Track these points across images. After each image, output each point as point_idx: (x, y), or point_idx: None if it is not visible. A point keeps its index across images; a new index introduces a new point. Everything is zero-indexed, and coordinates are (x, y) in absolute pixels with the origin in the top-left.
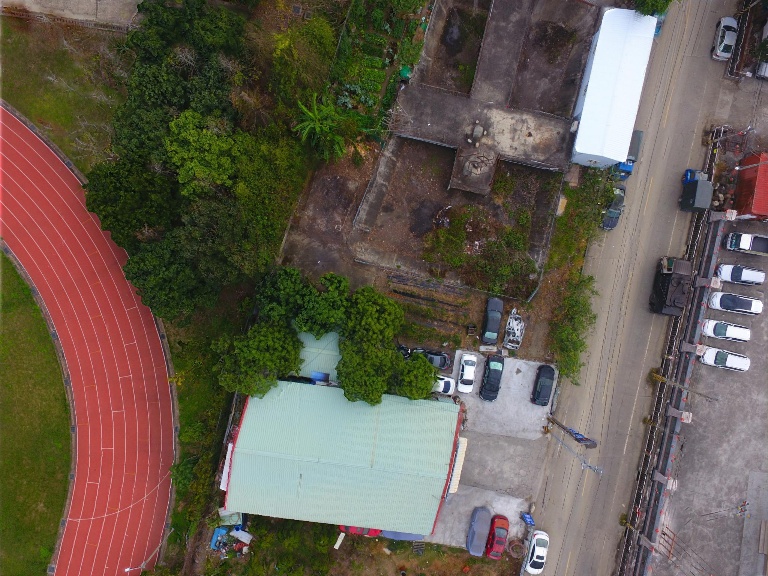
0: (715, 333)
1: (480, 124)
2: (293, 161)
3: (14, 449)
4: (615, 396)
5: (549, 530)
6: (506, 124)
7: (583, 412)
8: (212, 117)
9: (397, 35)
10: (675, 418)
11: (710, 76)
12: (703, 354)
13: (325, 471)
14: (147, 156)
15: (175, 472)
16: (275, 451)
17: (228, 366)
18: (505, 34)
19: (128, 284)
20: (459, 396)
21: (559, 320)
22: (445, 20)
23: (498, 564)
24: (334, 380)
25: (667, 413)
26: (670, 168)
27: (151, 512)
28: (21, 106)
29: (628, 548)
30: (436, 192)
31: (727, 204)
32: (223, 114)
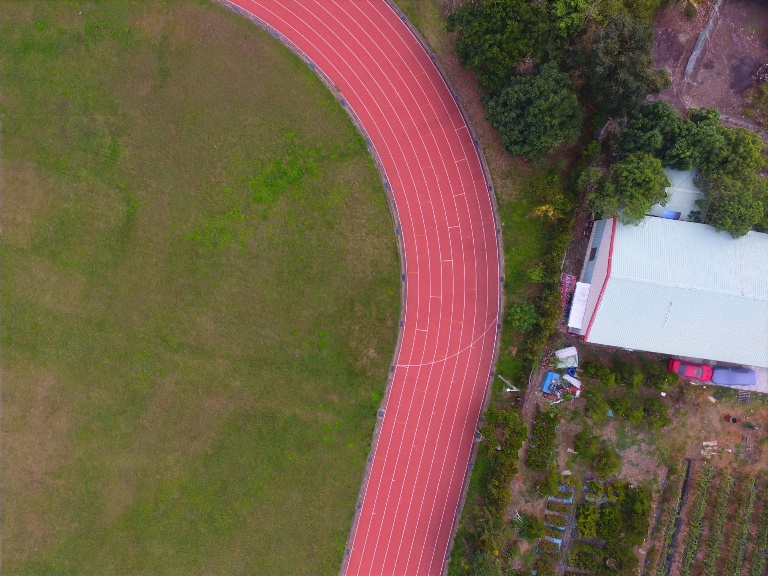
0: None
1: None
2: (654, 1)
3: (348, 296)
4: None
5: None
6: None
7: None
8: None
9: None
10: None
11: None
12: None
13: (696, 298)
14: None
15: (519, 312)
16: (650, 277)
17: (611, 191)
18: None
19: (458, 136)
20: None
21: None
22: None
23: None
24: (684, 219)
25: None
26: None
27: (477, 360)
28: None
29: None
30: (756, 49)
31: None
32: None
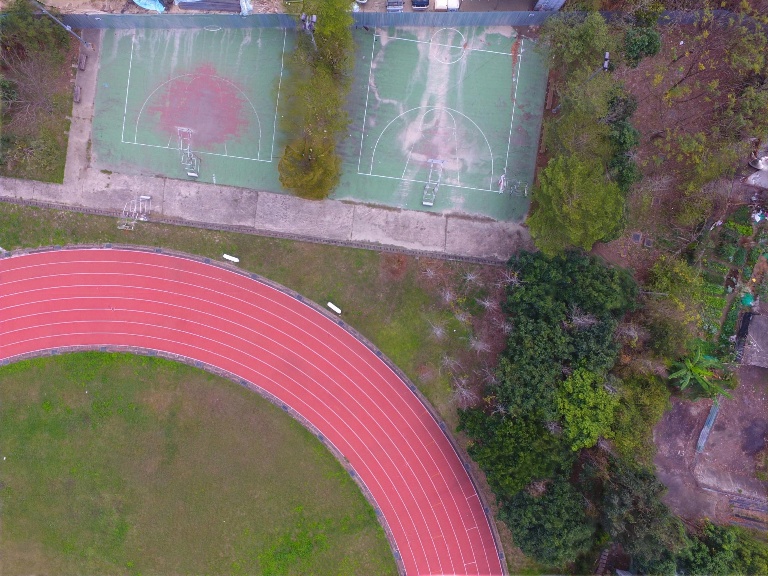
0: None
1: None
2: (666, 407)
3: None
4: None
5: None
6: None
7: None
8: None
9: (739, 263)
10: None
11: None
12: None
13: None
14: (541, 415)
15: None
16: None
17: None
18: None
19: (468, 505)
20: None
21: None
22: None
23: None
24: None
25: None
26: None
27: None
28: (368, 333)
29: None
30: (767, 411)
31: None
32: None
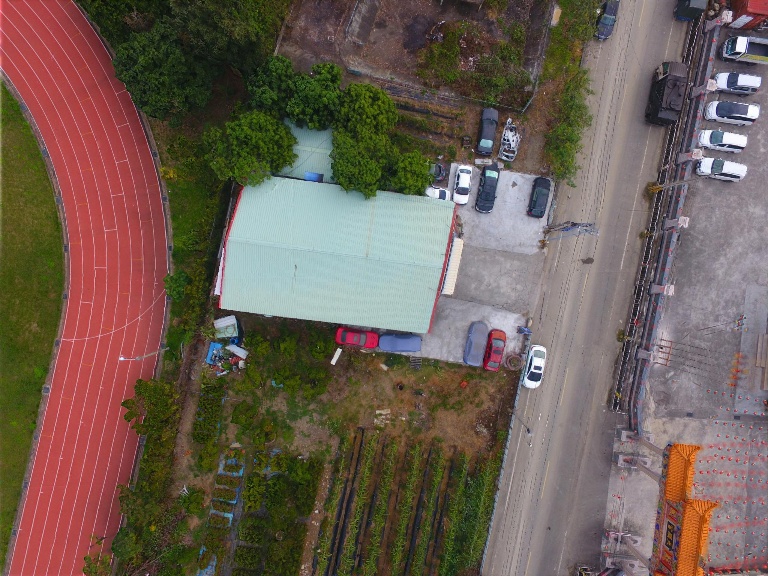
0: (711, 141)
1: None
2: None
3: (6, 268)
4: (611, 211)
5: (546, 345)
6: None
7: None
8: None
9: None
10: (672, 228)
11: None
12: (699, 164)
13: (320, 261)
14: None
15: (169, 280)
16: (269, 240)
17: (220, 150)
18: None
19: (119, 100)
20: None
21: None
22: None
23: (496, 380)
24: (328, 181)
25: (664, 226)
26: None
27: (146, 332)
28: None
29: (626, 360)
30: (429, 7)
31: (723, 11)
32: None
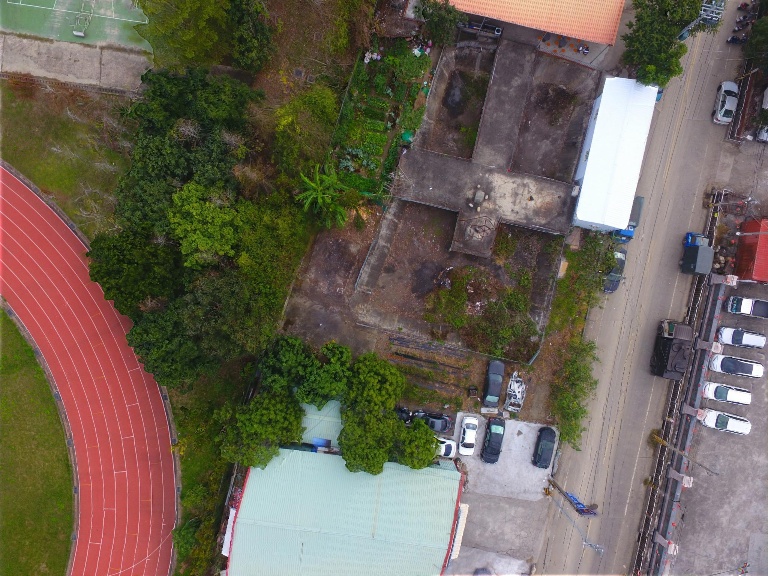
0: (716, 396)
1: (482, 188)
2: (295, 230)
3: (17, 510)
4: (616, 457)
5: None
6: (507, 188)
7: (584, 473)
8: (215, 188)
9: (399, 99)
10: (676, 481)
11: (711, 139)
12: None
13: (327, 541)
14: (150, 228)
15: (177, 536)
16: (277, 521)
17: (230, 438)
18: (507, 99)
19: None
20: (460, 458)
21: (560, 382)
22: (447, 83)
23: None
24: (336, 446)
25: (668, 475)
26: (671, 230)
27: (153, 572)
28: (25, 169)
29: None
30: (438, 253)
31: (728, 267)
32: (226, 185)
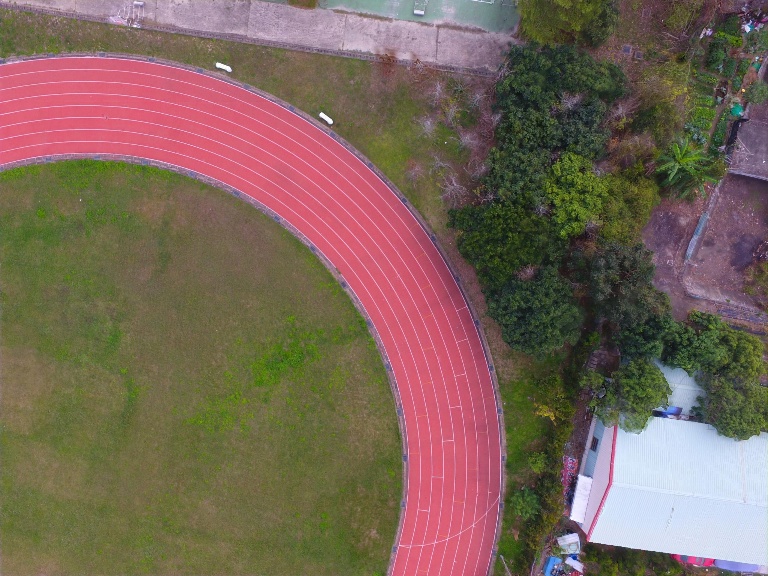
0: None
1: None
2: (654, 200)
3: (349, 477)
4: None
5: None
6: None
7: None
8: (587, 159)
9: (729, 74)
10: None
11: None
12: None
13: (699, 505)
14: (530, 198)
15: (521, 502)
16: (652, 485)
17: (612, 402)
18: None
19: (459, 317)
20: None
21: None
22: None
23: None
24: (686, 414)
25: None
26: None
27: (479, 539)
28: (360, 145)
29: None
30: (757, 226)
31: None
32: (595, 156)
